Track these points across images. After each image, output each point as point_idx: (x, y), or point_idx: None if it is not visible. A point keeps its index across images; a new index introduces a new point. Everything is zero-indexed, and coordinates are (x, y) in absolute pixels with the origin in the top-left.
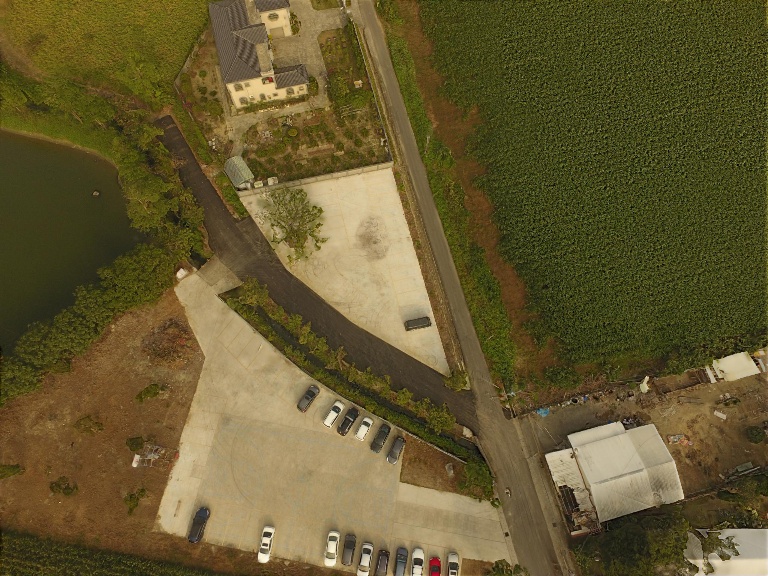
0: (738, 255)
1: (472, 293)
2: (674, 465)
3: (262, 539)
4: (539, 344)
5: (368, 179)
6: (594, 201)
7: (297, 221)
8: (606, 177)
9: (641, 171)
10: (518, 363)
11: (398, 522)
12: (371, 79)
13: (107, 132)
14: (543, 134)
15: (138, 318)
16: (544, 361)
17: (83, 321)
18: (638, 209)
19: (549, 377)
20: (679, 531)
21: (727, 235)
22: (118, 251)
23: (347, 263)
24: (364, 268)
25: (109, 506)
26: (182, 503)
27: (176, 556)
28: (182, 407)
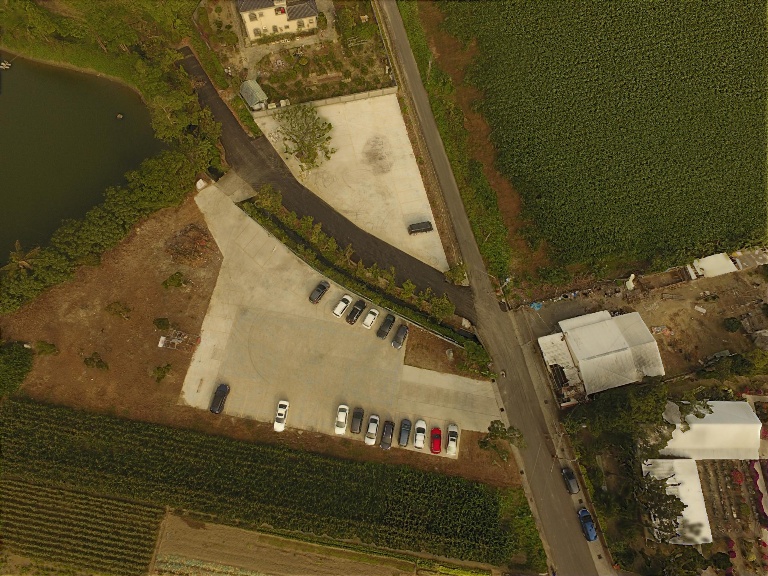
0: (719, 170)
1: (471, 202)
2: (656, 345)
3: (278, 410)
4: (533, 246)
5: (374, 103)
6: (585, 122)
7: (308, 136)
8: (596, 101)
9: (629, 96)
10: (513, 264)
11: (402, 398)
12: (376, 15)
13: (131, 56)
14: (538, 63)
15: (161, 223)
16: (537, 262)
17: (112, 217)
18: (626, 129)
19: (542, 275)
20: (658, 393)
21: (709, 152)
22: (144, 157)
23: (354, 176)
24: (370, 181)
25: (137, 383)
26: (204, 381)
27: (199, 425)
28: (203, 299)
